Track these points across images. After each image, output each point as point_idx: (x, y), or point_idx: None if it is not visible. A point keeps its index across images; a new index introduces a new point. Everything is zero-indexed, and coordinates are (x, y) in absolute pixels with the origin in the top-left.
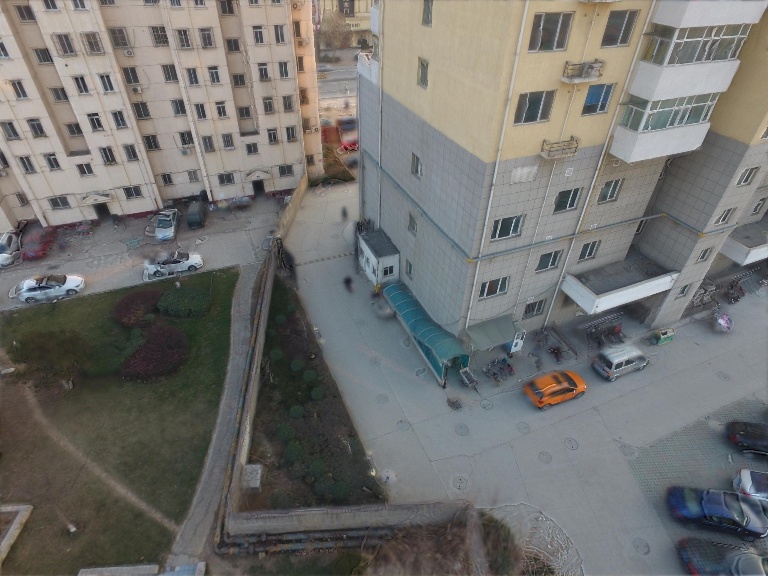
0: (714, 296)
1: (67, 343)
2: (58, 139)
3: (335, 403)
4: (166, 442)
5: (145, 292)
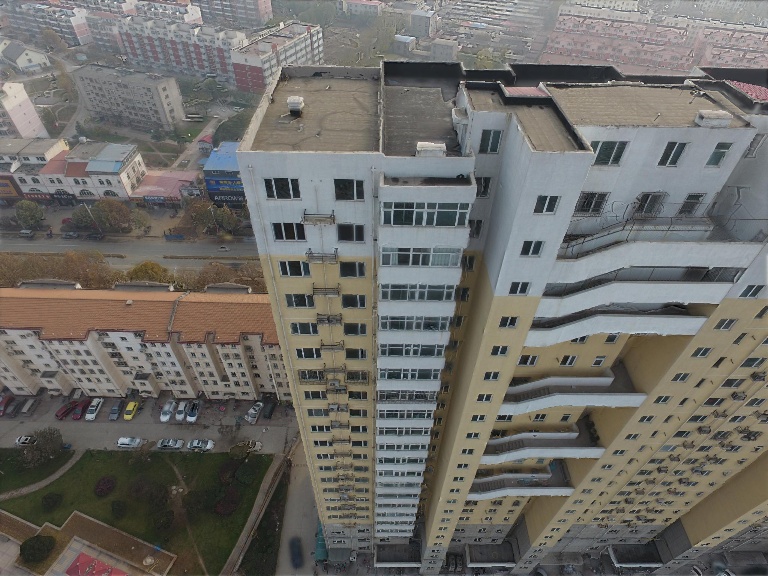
0: (464, 569)
1: (198, 498)
2: (218, 377)
3: (274, 557)
4: (218, 547)
5: (233, 463)
